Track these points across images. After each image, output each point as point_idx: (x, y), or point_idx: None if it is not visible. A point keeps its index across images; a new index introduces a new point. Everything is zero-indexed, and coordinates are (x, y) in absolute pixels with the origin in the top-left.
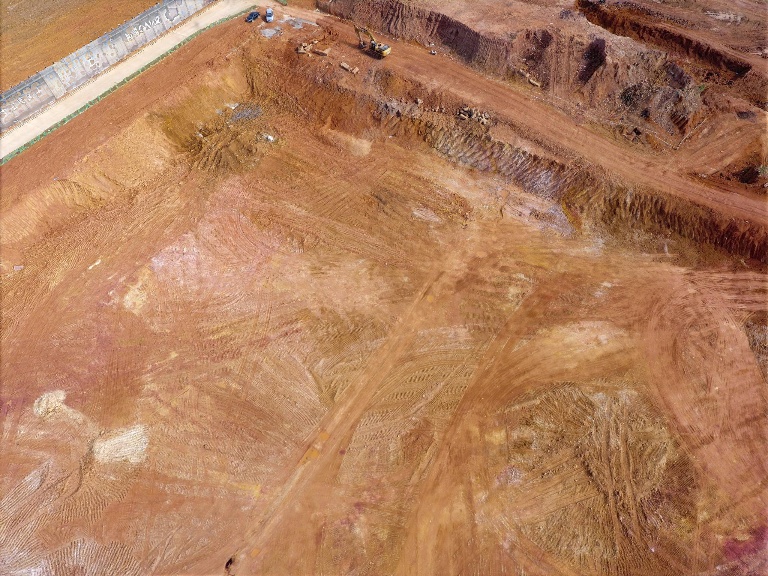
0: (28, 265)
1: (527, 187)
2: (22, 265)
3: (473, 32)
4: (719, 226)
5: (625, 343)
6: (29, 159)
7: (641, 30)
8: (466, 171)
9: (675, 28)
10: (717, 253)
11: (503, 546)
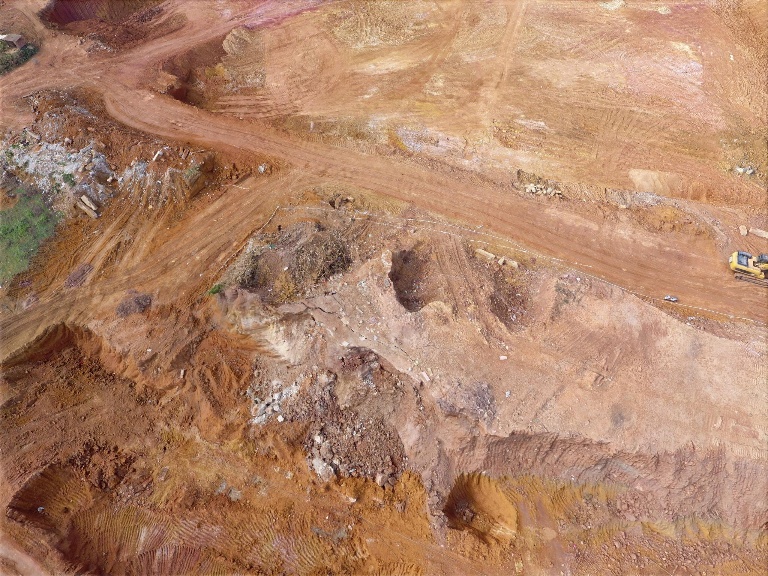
0: None
1: None
2: None
3: None
4: None
5: (357, 66)
6: None
7: None
8: None
9: None
10: None
11: (421, 0)
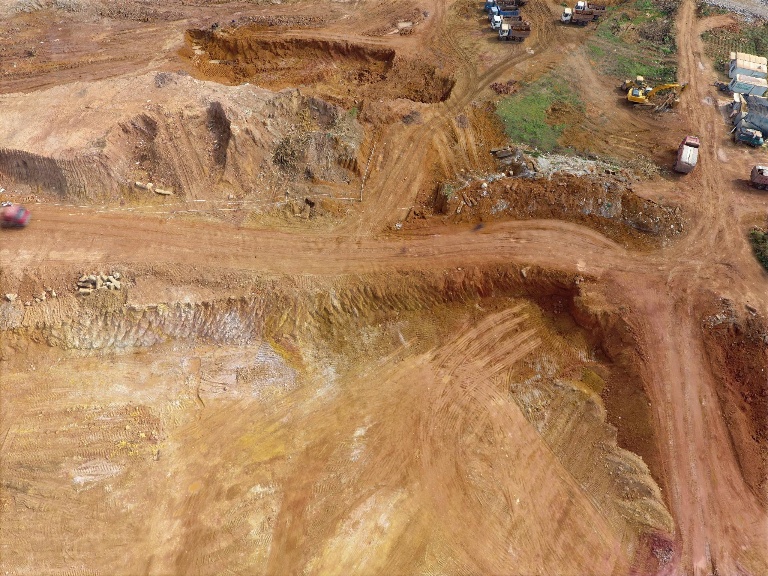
0: None
1: (218, 339)
2: None
3: (43, 159)
4: (437, 287)
5: (409, 509)
6: None
7: (272, 47)
8: (131, 358)
9: (305, 32)
10: (451, 311)
11: None
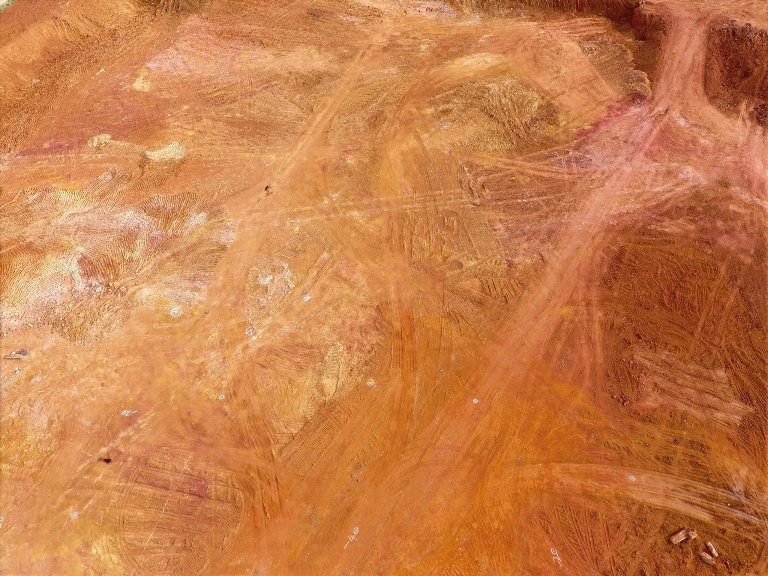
0: (43, 79)
1: None
2: (38, 79)
3: None
4: None
5: (503, 60)
6: (19, 8)
7: None
8: None
9: None
10: (556, 12)
11: (444, 153)
